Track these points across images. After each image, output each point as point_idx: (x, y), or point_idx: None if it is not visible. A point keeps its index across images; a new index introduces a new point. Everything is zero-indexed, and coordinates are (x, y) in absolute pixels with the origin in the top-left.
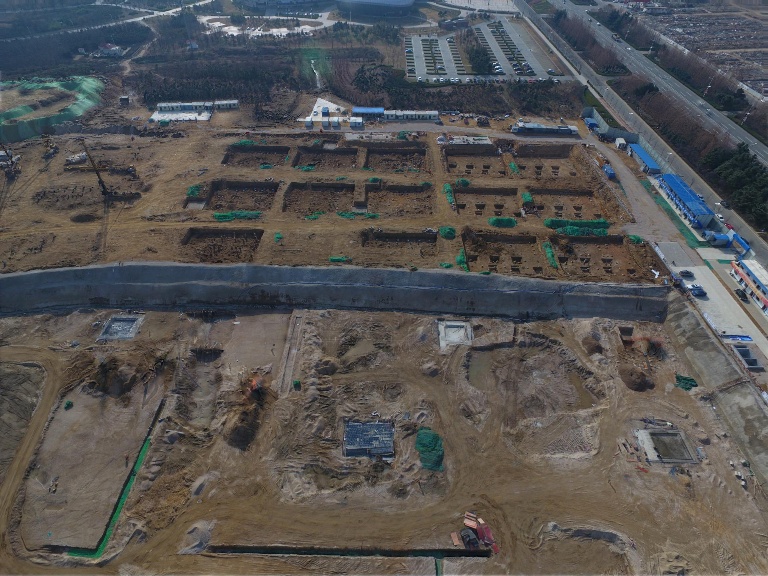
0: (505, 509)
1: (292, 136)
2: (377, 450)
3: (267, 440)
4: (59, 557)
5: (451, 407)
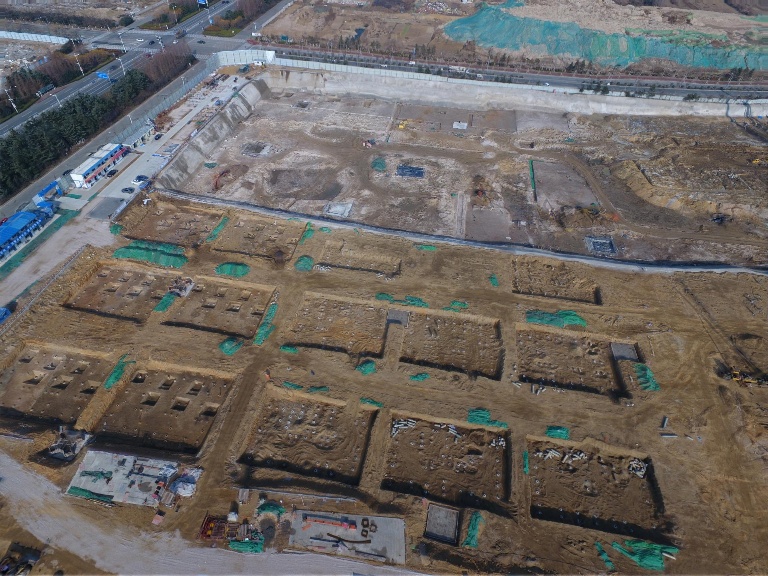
0: (351, 147)
1: (540, 572)
2: (407, 168)
3: (466, 176)
4: (546, 159)
5: (360, 176)
